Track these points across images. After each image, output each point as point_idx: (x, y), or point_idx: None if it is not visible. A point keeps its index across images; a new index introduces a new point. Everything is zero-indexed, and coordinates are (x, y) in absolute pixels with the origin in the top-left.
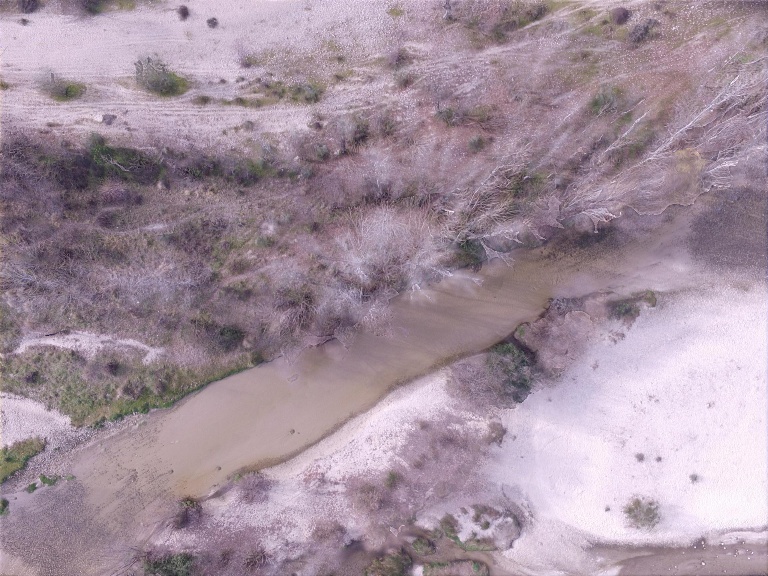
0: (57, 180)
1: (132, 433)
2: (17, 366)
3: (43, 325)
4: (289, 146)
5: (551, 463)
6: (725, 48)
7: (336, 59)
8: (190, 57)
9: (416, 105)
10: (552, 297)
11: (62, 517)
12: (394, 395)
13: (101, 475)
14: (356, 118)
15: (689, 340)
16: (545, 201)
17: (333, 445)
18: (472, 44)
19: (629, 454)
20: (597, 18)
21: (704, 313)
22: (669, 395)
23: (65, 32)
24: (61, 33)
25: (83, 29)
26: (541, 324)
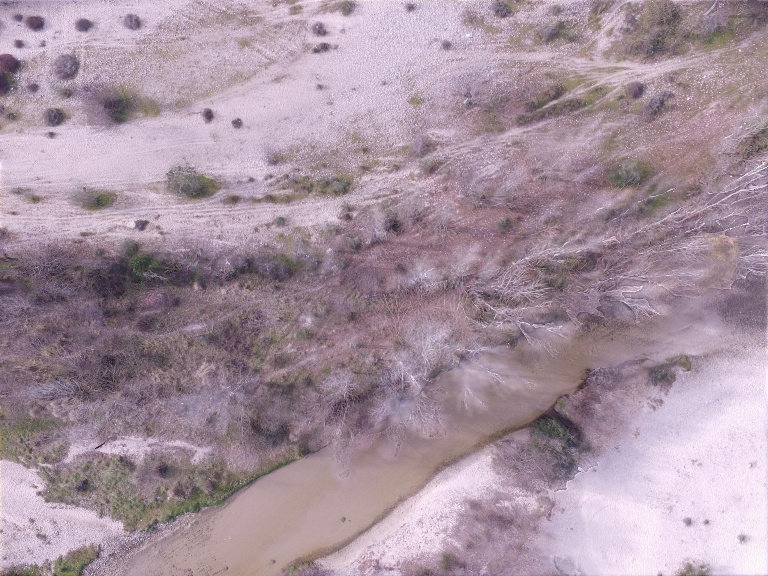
0: (94, 289)
1: (185, 533)
2: (66, 476)
3: (89, 433)
4: (321, 239)
5: (601, 533)
6: (739, 114)
7: (361, 150)
8: (217, 158)
9: (443, 190)
10: (589, 368)
11: None
12: (441, 476)
13: None
14: (387, 211)
15: (726, 402)
16: (576, 276)
17: (385, 530)
18: (493, 127)
19: (677, 519)
20: (613, 93)
21: (738, 374)
22: (711, 458)
23: (92, 142)
24: (88, 143)
25: (110, 138)
26: (580, 396)
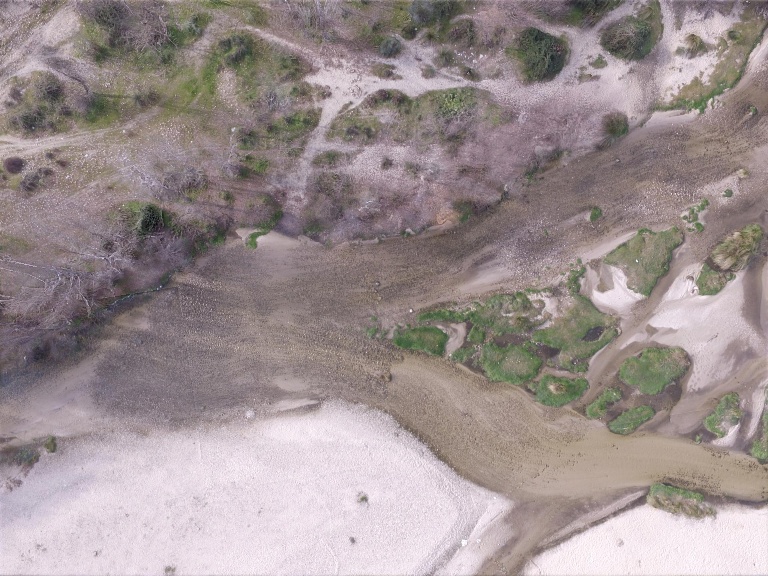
0: None
1: None
2: None
3: None
4: None
5: None
6: (119, 196)
7: None
8: None
9: None
10: None
11: None
12: None
13: None
14: None
15: (84, 486)
16: None
17: None
18: None
19: None
20: None
21: (101, 458)
22: (57, 543)
23: None
24: None
25: None
26: None
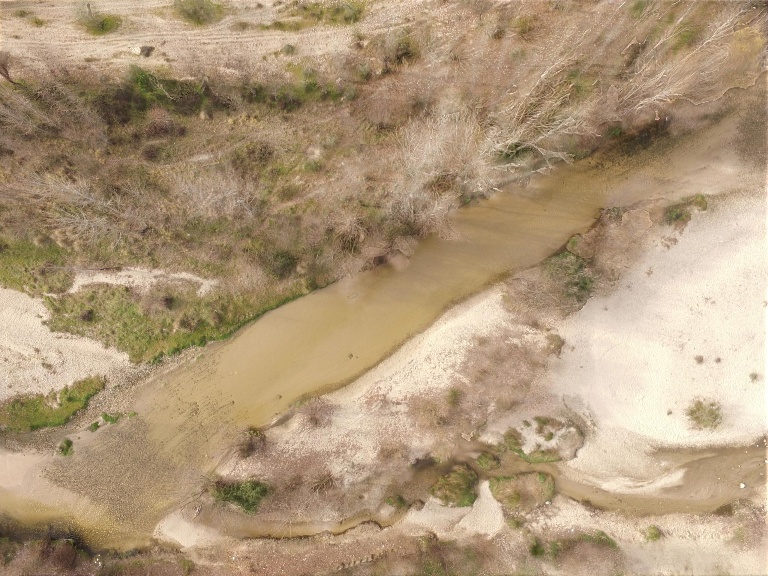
0: (99, 115)
1: (191, 367)
2: (71, 305)
3: (95, 263)
4: (331, 68)
5: (611, 371)
6: None
7: None
8: None
9: (456, 19)
10: (602, 207)
11: (126, 454)
12: (450, 314)
13: (162, 410)
14: (399, 32)
15: (742, 241)
16: None
17: (392, 367)
18: None
19: (688, 357)
20: None
21: (755, 213)
22: (725, 296)
23: None
24: None
25: None
26: (593, 234)
